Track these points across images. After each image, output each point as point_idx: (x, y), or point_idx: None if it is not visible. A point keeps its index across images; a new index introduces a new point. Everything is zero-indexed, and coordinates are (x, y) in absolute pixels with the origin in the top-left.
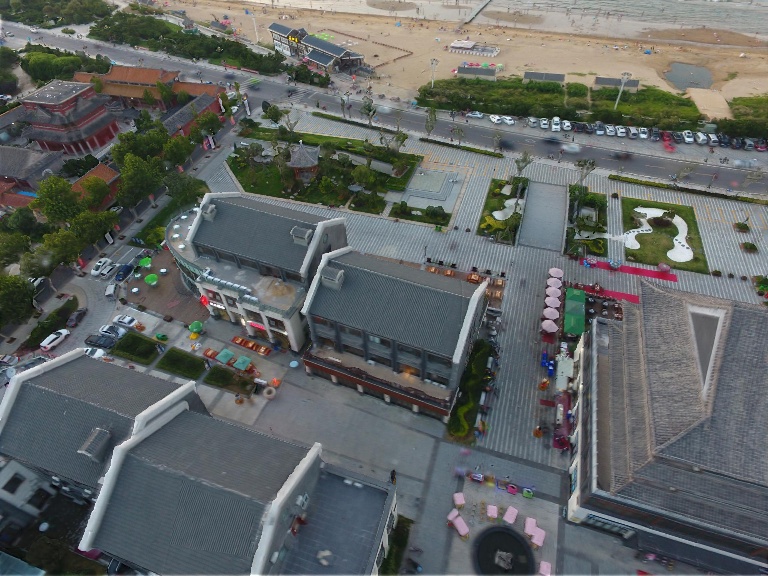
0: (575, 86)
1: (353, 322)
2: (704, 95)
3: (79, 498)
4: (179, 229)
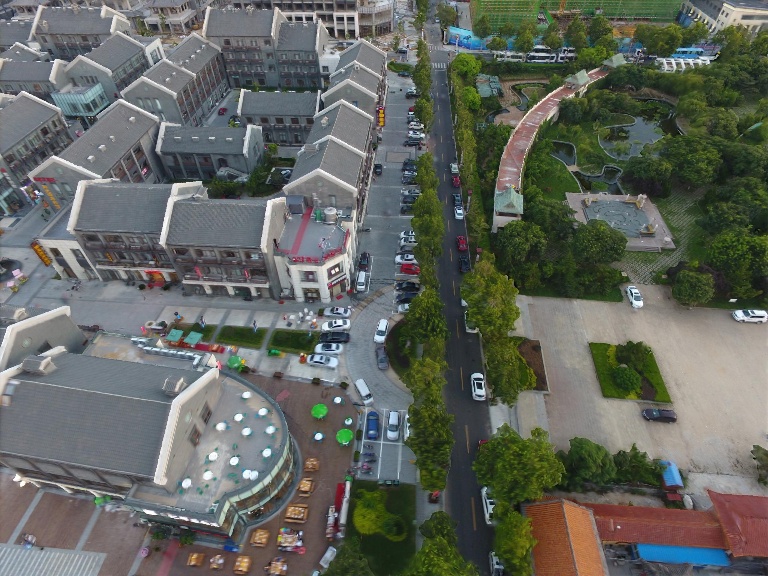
0: None
1: None
2: None
3: None
4: None
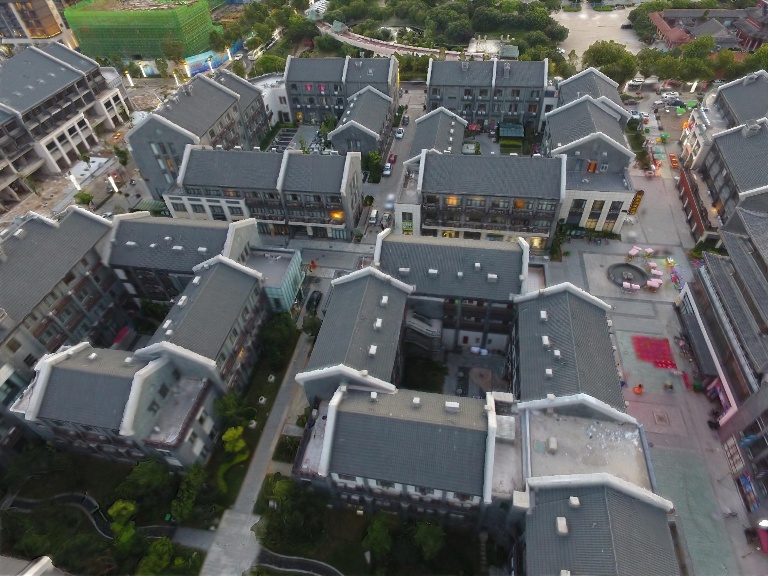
0: None
1: (726, 154)
2: None
3: None
4: None
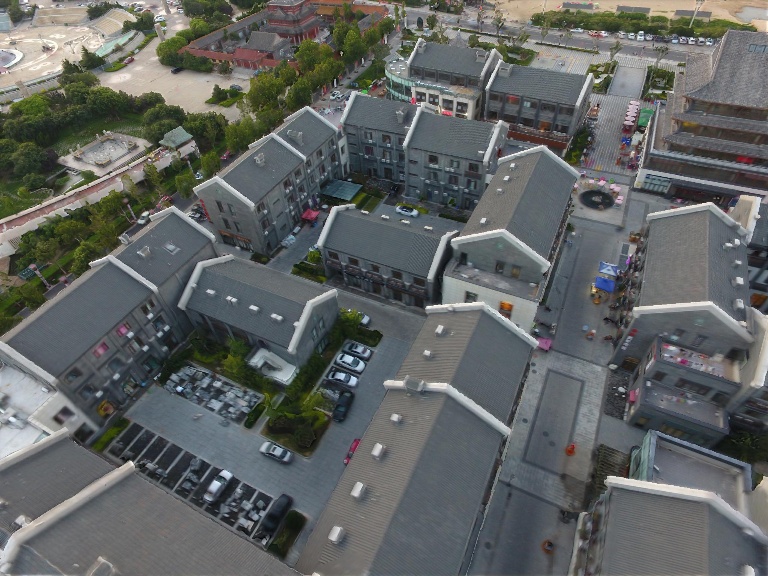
0: (658, 16)
1: (516, 92)
2: (765, 24)
3: (364, 172)
4: (393, 67)
